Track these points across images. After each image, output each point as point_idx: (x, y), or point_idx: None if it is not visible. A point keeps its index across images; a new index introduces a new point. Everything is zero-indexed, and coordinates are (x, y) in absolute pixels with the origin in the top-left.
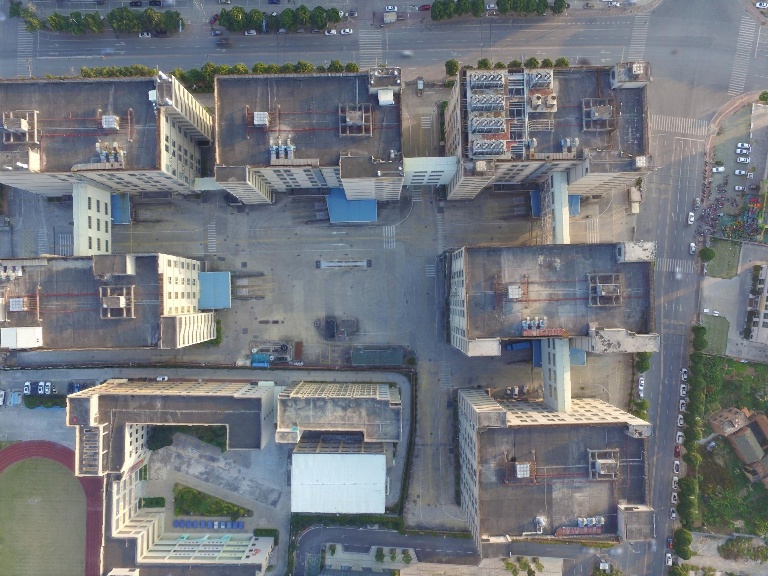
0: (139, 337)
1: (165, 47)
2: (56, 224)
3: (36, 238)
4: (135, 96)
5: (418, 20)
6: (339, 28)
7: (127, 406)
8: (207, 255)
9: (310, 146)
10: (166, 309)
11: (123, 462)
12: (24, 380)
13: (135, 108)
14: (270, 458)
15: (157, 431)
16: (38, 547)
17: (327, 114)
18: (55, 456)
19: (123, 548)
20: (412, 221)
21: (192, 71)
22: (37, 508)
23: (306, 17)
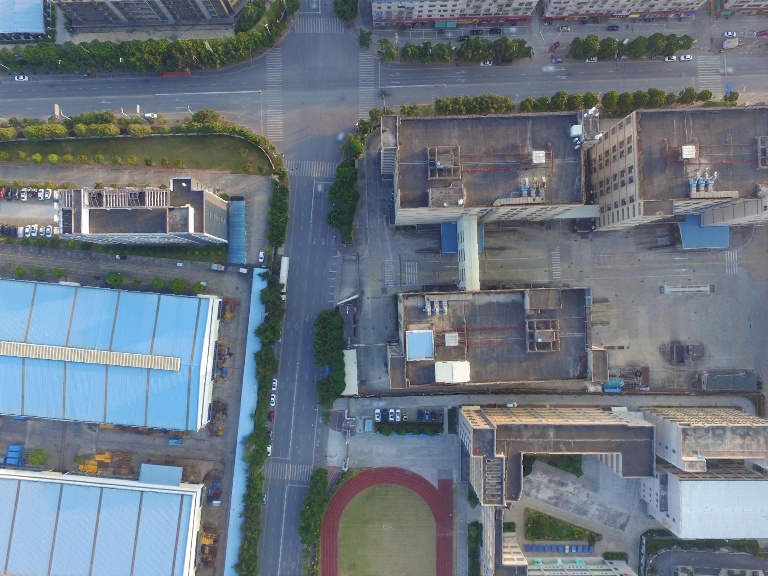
0: (561, 370)
1: (505, 75)
2: (402, 252)
3: (382, 266)
4: (553, 130)
5: (756, 45)
6: (678, 54)
7: (520, 436)
8: (552, 282)
9: (727, 178)
10: (587, 342)
11: (518, 491)
12: (373, 407)
13: (553, 142)
14: (618, 482)
15: (528, 458)
16: (390, 572)
17: (743, 146)
18: (404, 482)
19: (511, 575)
20: (754, 246)
21: (544, 100)
22: (388, 534)
23: (664, 45)
